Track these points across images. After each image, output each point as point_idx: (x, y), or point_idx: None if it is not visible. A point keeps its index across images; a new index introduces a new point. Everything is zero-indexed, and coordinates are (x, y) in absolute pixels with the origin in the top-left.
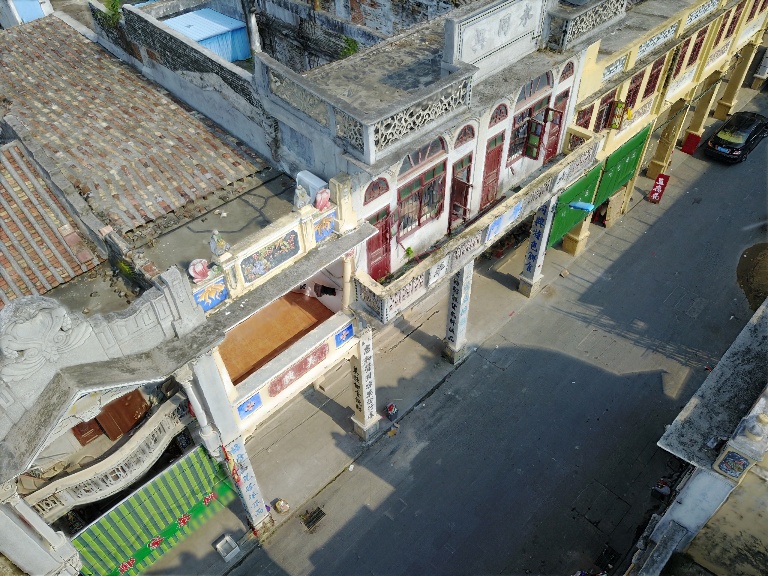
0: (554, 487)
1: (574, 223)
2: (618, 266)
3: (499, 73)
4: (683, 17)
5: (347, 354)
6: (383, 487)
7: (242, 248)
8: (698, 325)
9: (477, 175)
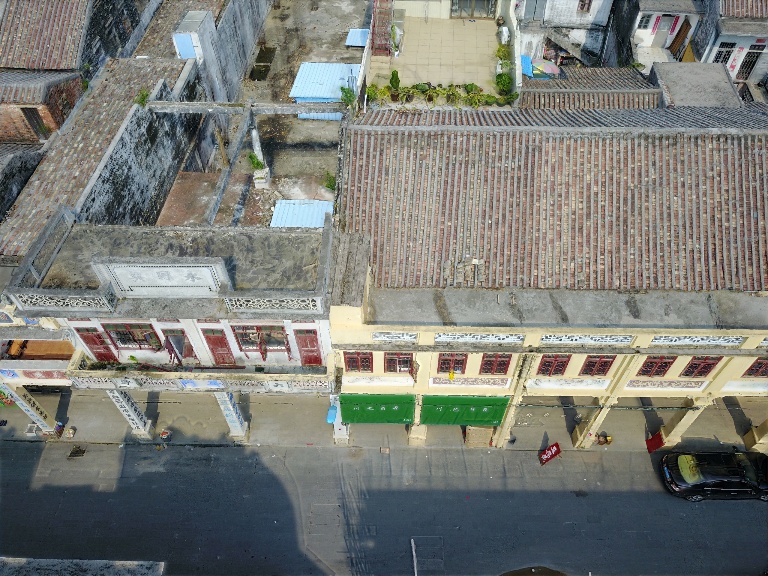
0: (177, 562)
1: (388, 421)
2: (428, 481)
3: (173, 299)
4: (527, 334)
5: None
6: (117, 471)
7: None
8: (406, 575)
9: (198, 344)
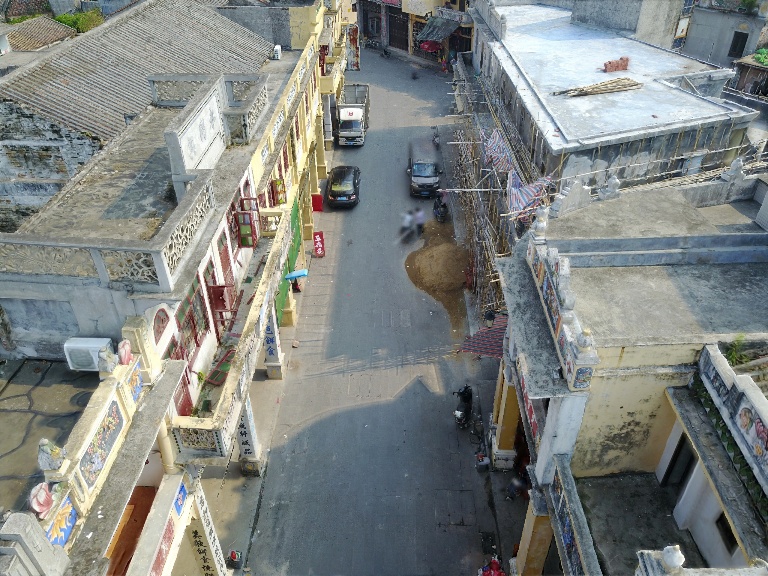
0: (414, 519)
1: (285, 296)
2: (331, 317)
3: (212, 175)
4: (285, 102)
5: (187, 519)
6: None
7: (76, 447)
8: (415, 330)
9: (220, 278)
